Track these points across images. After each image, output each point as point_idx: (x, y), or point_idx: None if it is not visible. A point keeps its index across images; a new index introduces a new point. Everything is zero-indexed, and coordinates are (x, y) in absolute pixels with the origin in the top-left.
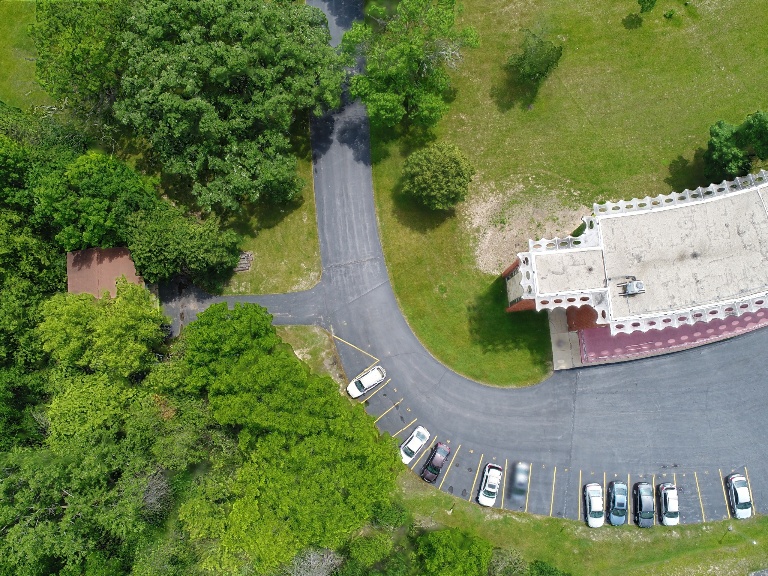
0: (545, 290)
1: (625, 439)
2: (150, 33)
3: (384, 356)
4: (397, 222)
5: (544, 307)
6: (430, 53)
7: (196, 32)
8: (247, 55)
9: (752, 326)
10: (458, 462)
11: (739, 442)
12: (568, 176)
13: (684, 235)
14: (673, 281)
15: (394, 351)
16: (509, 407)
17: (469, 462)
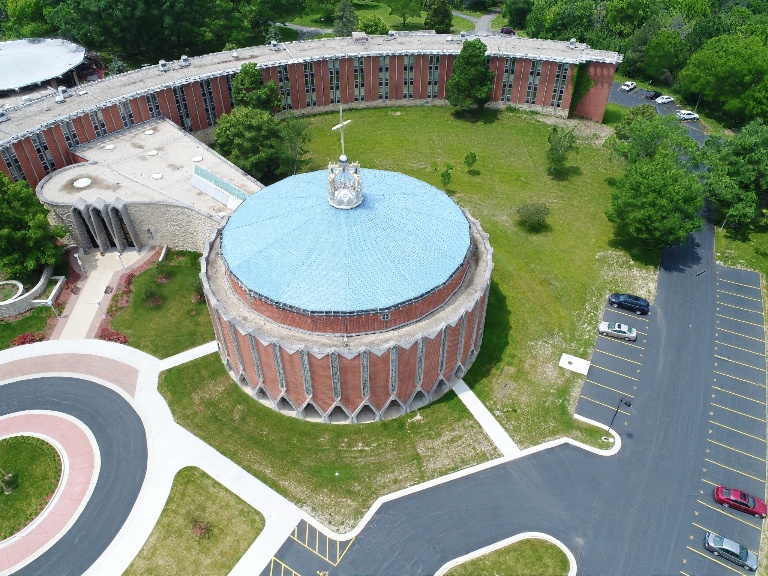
0: None
1: None
2: None
3: None
4: None
5: None
6: None
7: None
8: None
9: None
10: None
11: None
12: None
13: None
14: None
15: None
16: None
17: None
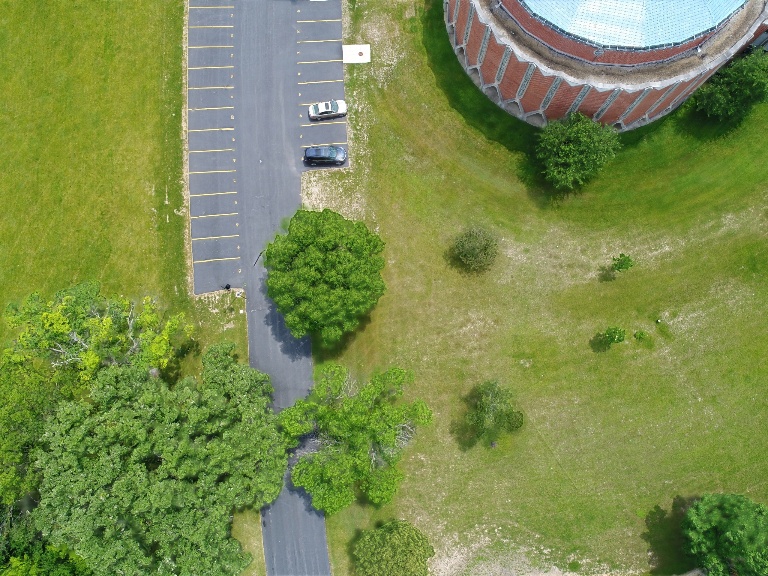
0: None
1: None
2: (64, 463)
3: None
4: None
5: None
6: None
7: (115, 456)
8: (171, 493)
9: None
10: None
11: None
12: (537, 530)
13: None
14: None
15: None
16: None
17: None
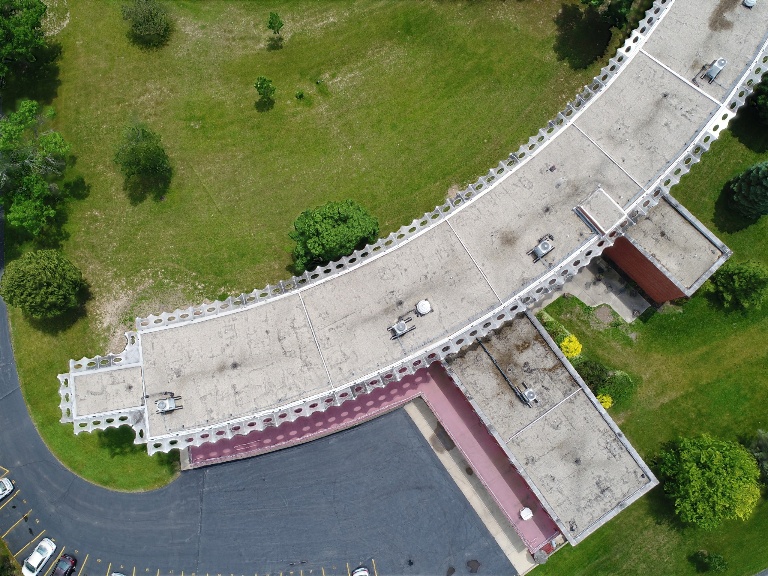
0: (83, 412)
1: (252, 538)
2: None
3: (14, 466)
4: (29, 326)
5: (82, 430)
6: (18, 161)
7: None
8: None
9: (357, 417)
10: (86, 573)
11: (367, 533)
12: (194, 269)
13: (224, 345)
14: (212, 394)
15: (23, 460)
16: (137, 512)
17: (97, 572)
